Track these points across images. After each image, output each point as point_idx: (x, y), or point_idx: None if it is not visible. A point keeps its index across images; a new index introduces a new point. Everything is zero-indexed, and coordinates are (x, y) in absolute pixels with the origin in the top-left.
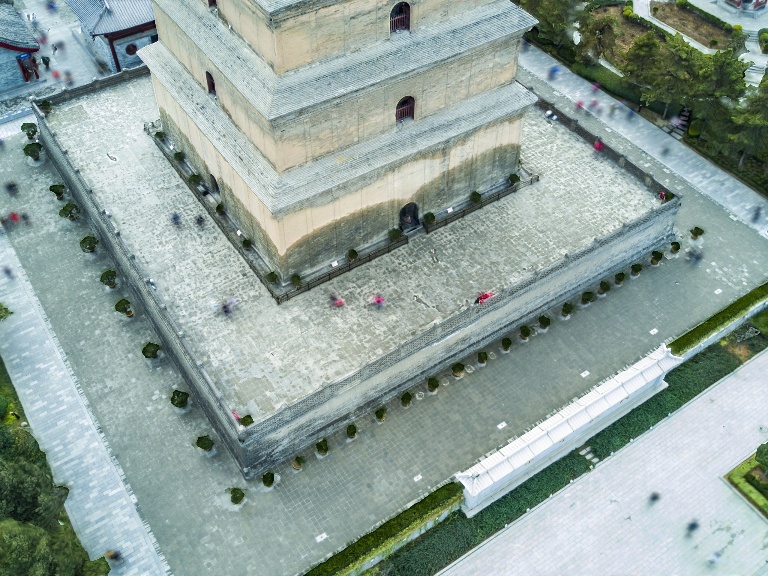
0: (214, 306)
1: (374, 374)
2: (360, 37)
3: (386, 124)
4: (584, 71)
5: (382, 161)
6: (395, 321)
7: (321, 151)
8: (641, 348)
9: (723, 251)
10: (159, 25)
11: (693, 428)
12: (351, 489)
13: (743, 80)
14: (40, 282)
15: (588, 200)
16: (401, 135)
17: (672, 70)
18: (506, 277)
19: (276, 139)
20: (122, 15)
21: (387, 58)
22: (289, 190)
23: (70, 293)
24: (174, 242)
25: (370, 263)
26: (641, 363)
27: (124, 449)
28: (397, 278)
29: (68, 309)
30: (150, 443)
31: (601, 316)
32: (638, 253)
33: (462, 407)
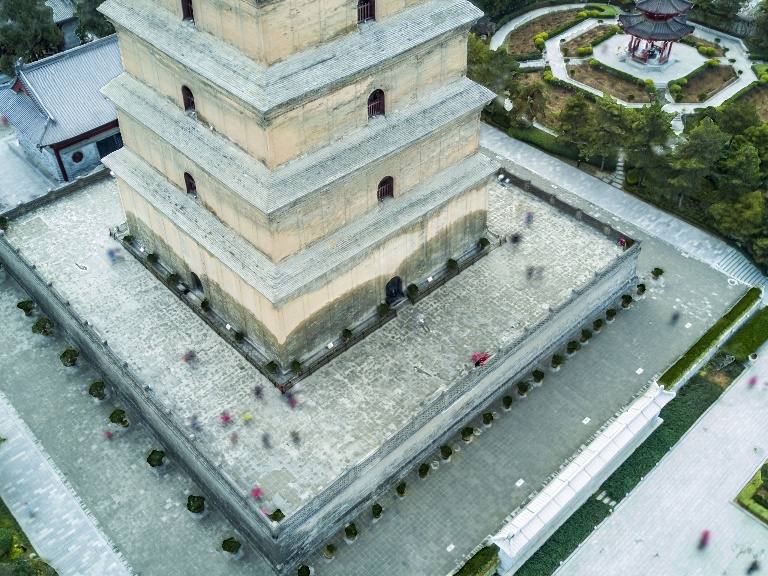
0: (218, 404)
1: (392, 450)
2: (342, 126)
3: (369, 205)
4: (521, 134)
5: (370, 240)
6: (401, 394)
7: (313, 237)
8: (632, 388)
9: (684, 287)
10: (125, 132)
11: (695, 458)
12: (387, 570)
13: (672, 129)
14: (23, 403)
15: (556, 254)
16: (384, 213)
17: (606, 126)
18: (497, 337)
19: (272, 231)
20: (67, 124)
21: (368, 143)
22: (287, 279)
23: (57, 411)
24: (163, 344)
25: (364, 340)
26: (639, 403)
27: (145, 565)
28: (394, 352)
29: (58, 427)
30: (172, 555)
31: (588, 363)
32: (609, 299)
33: (478, 470)
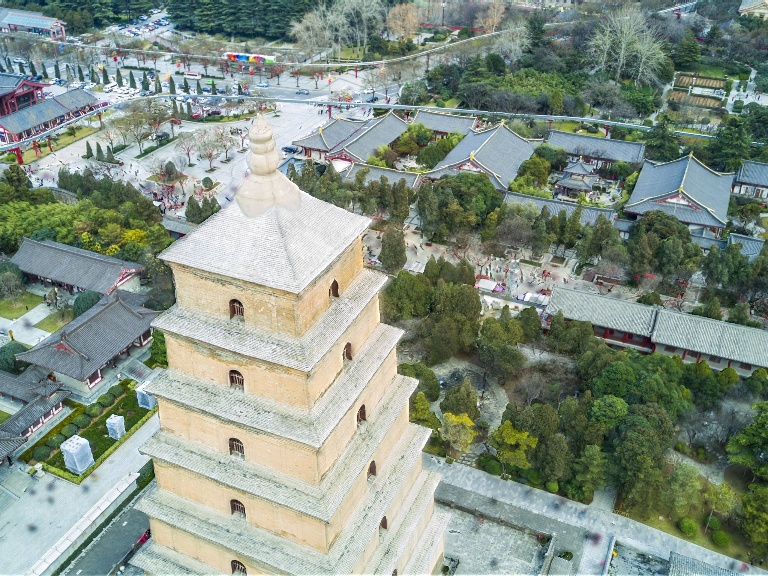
0: None
1: None
2: None
3: None
4: None
5: None
6: None
7: None
8: None
9: None
10: None
11: None
12: None
13: None
14: None
15: None
16: None
17: None
18: (138, 569)
19: None
20: None
21: None
22: None
23: None
24: None
25: None
26: (44, 568)
27: None
28: None
29: None
30: None
31: None
32: None
33: None
